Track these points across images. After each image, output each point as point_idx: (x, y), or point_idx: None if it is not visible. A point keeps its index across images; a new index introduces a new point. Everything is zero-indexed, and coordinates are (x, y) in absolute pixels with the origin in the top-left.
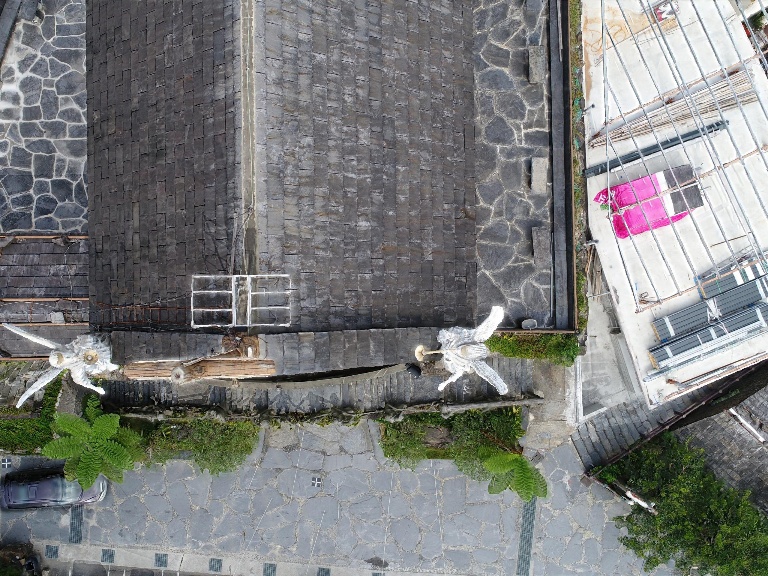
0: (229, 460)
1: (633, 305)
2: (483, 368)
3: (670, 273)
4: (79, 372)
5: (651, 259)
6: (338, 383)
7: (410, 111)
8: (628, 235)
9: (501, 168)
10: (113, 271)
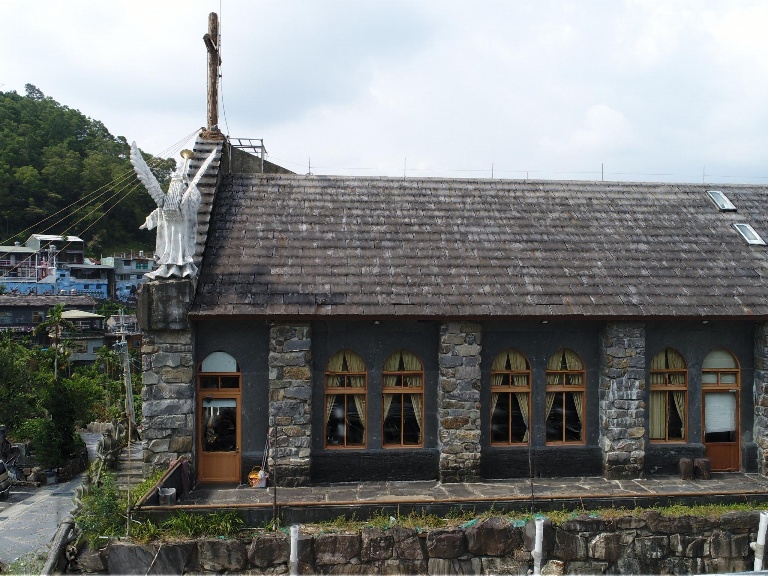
0: None
1: None
2: (157, 184)
3: None
4: None
5: None
6: None
7: (415, 259)
8: None
9: None
10: None
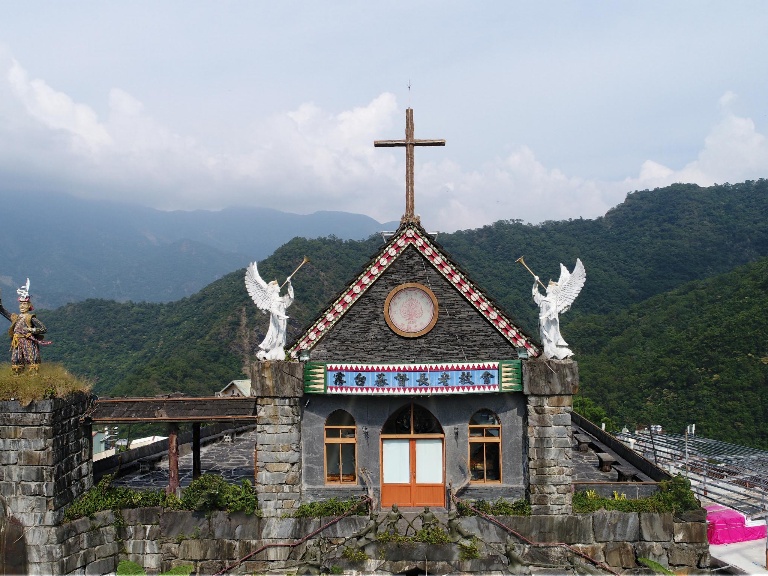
0: None
1: (761, 571)
2: None
3: (760, 500)
4: (279, 303)
5: (756, 552)
6: (461, 361)
7: None
8: (722, 543)
9: (575, 467)
10: None
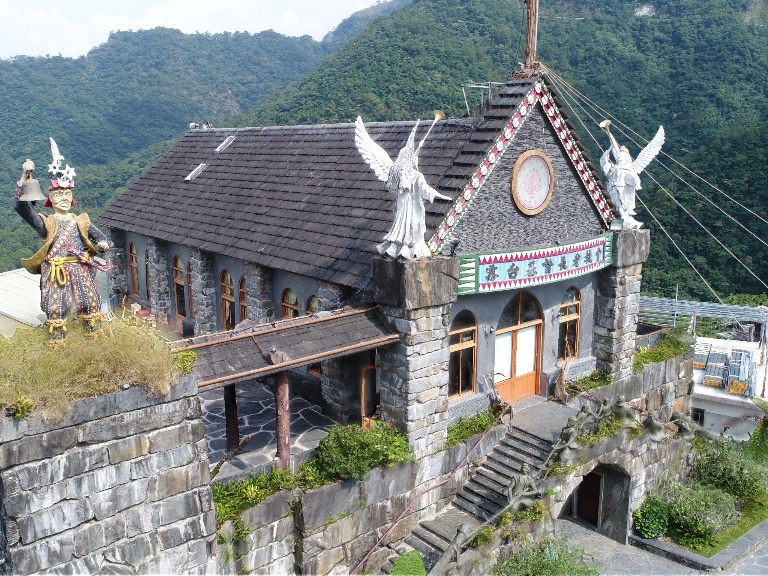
0: (584, 573)
1: None
2: None
3: None
4: None
5: None
6: (587, 239)
7: None
8: None
9: None
10: (362, 245)
